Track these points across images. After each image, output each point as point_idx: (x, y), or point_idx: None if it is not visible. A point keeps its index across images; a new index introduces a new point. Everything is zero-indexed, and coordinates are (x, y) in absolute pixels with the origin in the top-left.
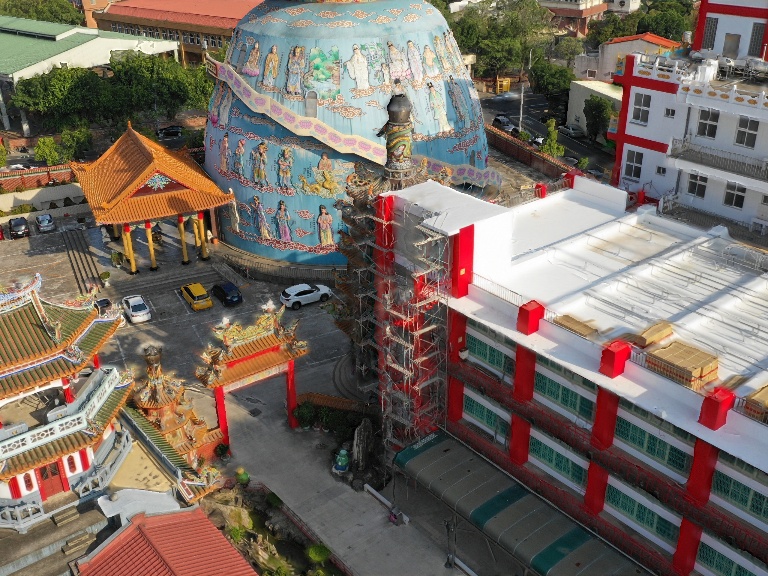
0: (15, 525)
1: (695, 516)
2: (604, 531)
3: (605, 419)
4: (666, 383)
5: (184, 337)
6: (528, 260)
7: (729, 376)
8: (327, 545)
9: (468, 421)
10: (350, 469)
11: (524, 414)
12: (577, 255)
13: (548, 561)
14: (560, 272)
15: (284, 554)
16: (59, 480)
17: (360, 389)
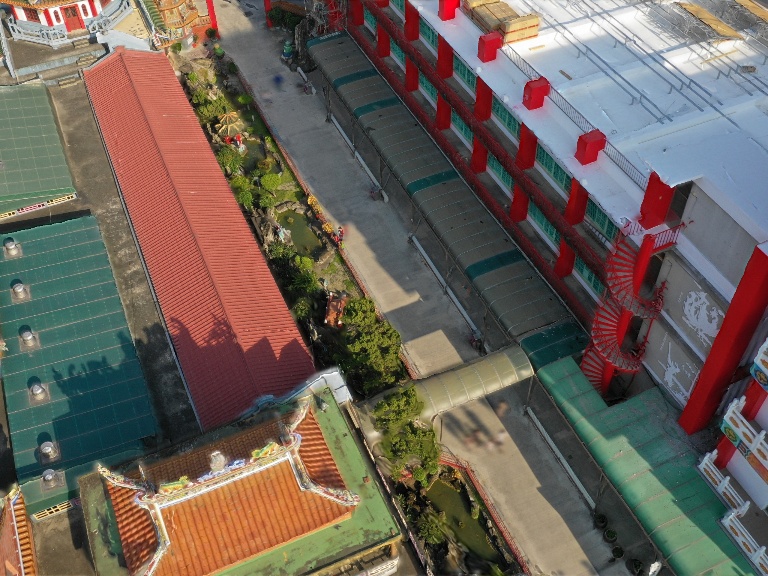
0: (50, 43)
1: (434, 82)
2: (407, 99)
3: (408, 17)
4: None
5: None
6: None
7: None
8: (257, 99)
9: (366, 26)
10: (292, 56)
11: (374, 14)
12: None
13: (363, 111)
14: None
15: (228, 100)
16: (78, 20)
17: None
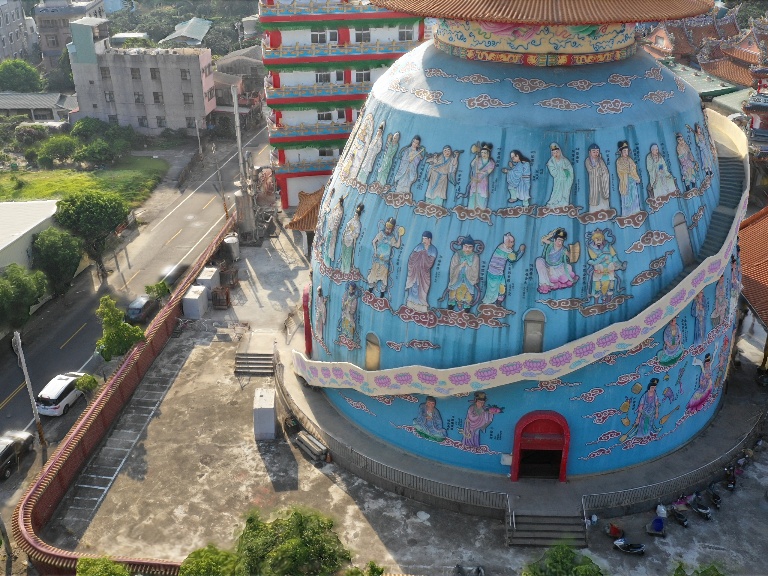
0: None
1: None
2: None
3: None
4: None
5: None
6: None
7: None
8: None
9: None
10: None
11: None
12: None
13: None
14: None
15: None
16: None
17: None
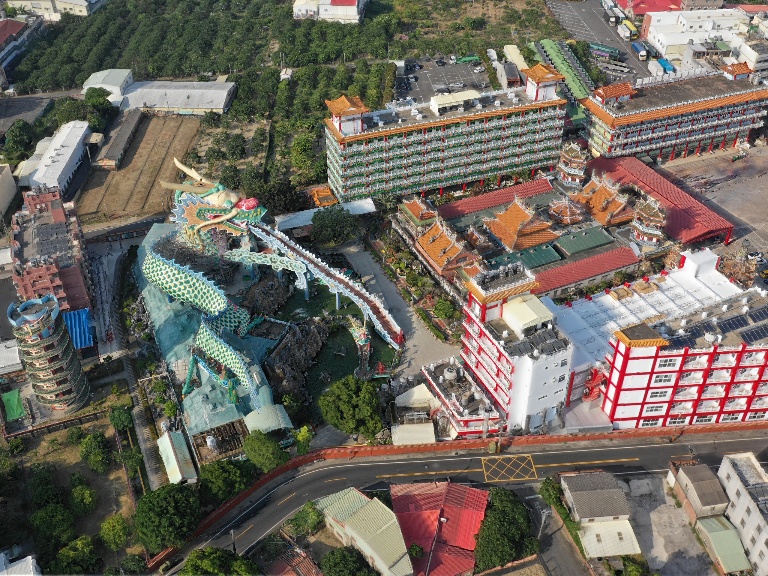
0: None
1: None
2: None
3: None
4: None
5: None
6: (698, 281)
7: None
8: None
9: None
10: None
11: None
12: (705, 292)
13: None
14: (694, 287)
15: None
16: None
17: None
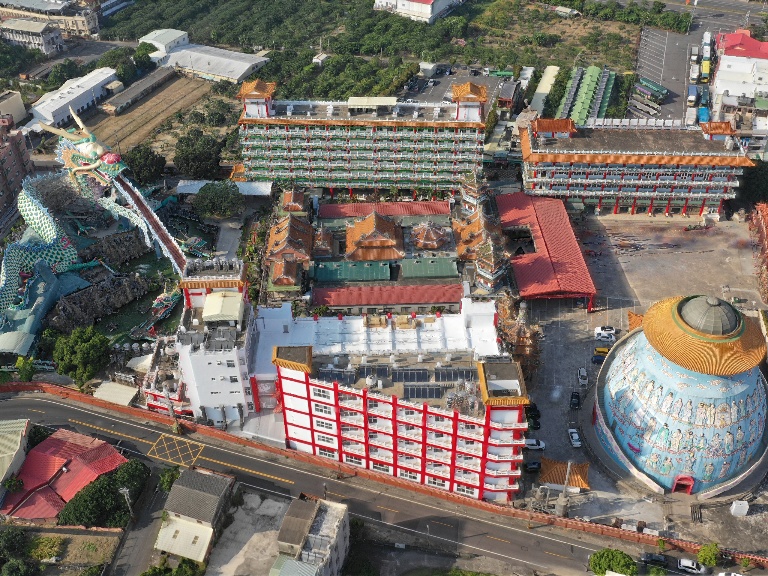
0: None
1: None
2: None
3: None
4: None
5: (578, 344)
6: None
7: None
8: None
9: None
10: None
11: None
12: (461, 344)
13: None
14: None
15: None
16: None
17: None
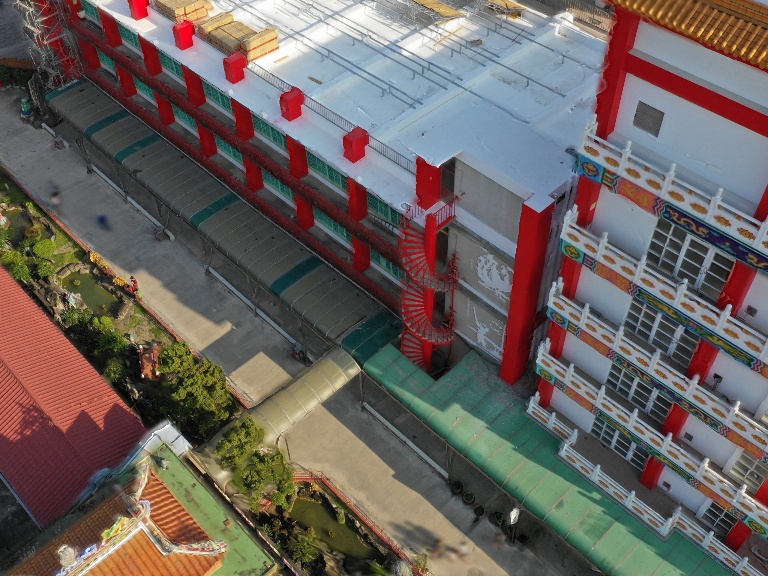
0: None
1: (189, 112)
2: (166, 134)
3: (146, 52)
4: (166, 21)
5: None
6: None
7: (218, 14)
8: (6, 166)
9: (104, 68)
10: (32, 114)
11: (109, 55)
12: None
13: (124, 155)
14: None
15: None
16: None
17: (38, 52)
